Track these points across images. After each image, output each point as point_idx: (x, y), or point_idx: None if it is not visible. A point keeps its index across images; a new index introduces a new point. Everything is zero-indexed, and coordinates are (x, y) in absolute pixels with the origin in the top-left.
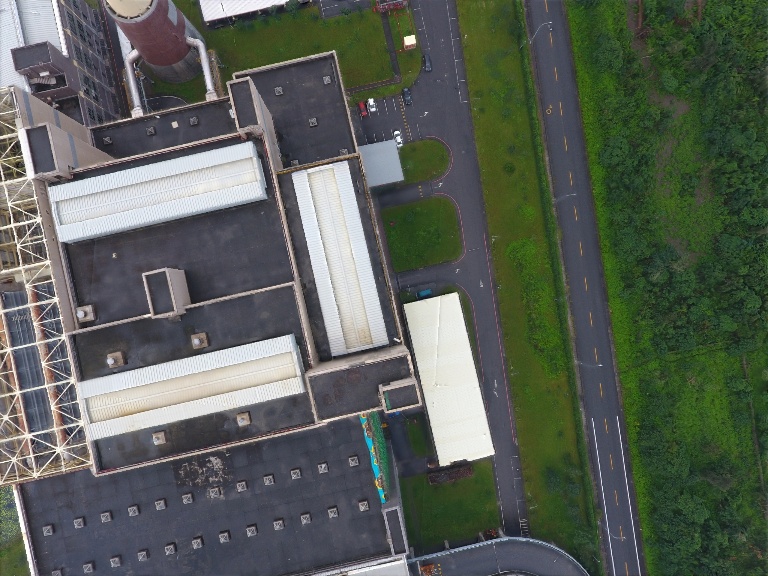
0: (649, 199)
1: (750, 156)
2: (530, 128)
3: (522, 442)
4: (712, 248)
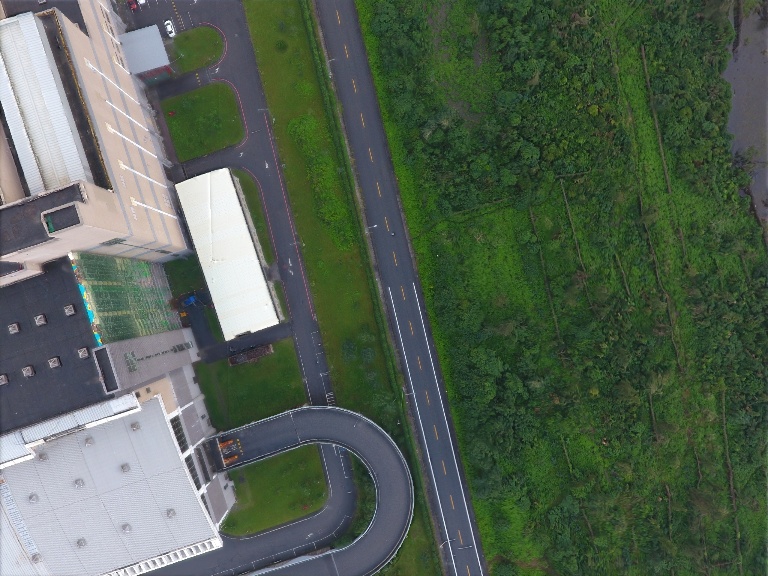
0: (427, 65)
1: (518, 9)
2: (299, 4)
3: (321, 317)
4: (493, 107)
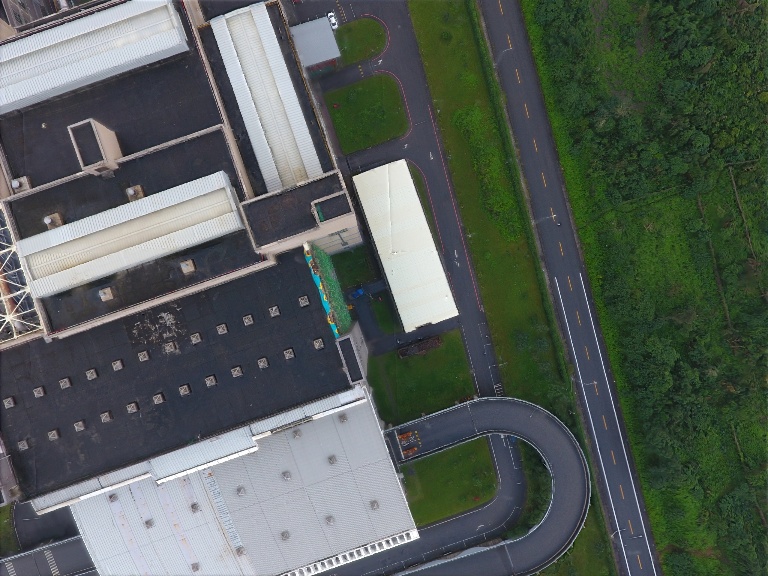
0: (590, 54)
1: None
2: None
3: (488, 308)
4: (657, 96)
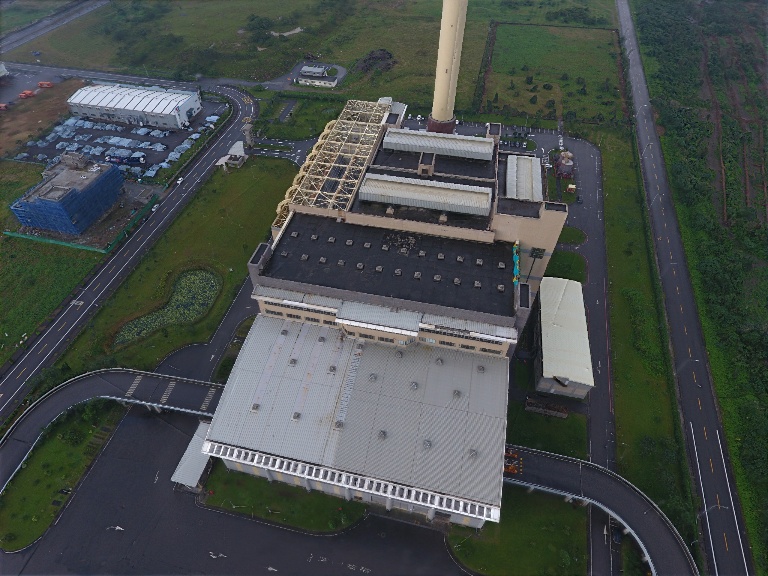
0: (739, 301)
1: None
2: (645, 240)
3: (619, 413)
4: None
